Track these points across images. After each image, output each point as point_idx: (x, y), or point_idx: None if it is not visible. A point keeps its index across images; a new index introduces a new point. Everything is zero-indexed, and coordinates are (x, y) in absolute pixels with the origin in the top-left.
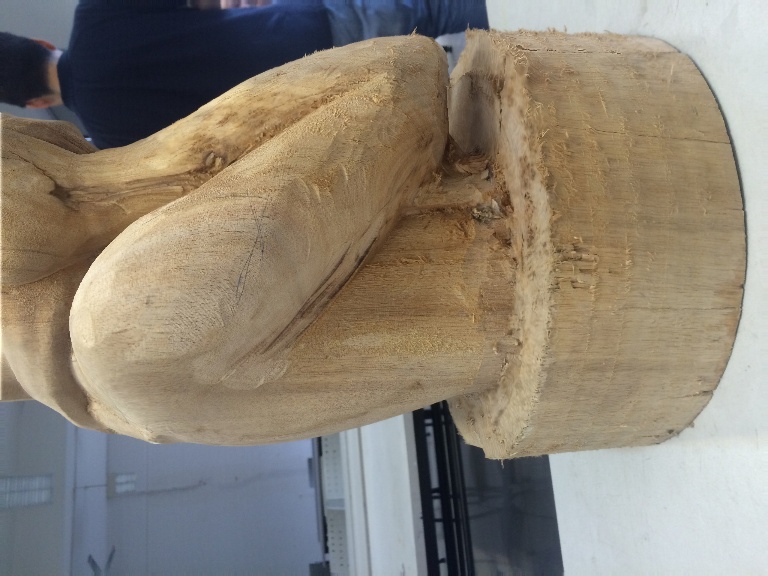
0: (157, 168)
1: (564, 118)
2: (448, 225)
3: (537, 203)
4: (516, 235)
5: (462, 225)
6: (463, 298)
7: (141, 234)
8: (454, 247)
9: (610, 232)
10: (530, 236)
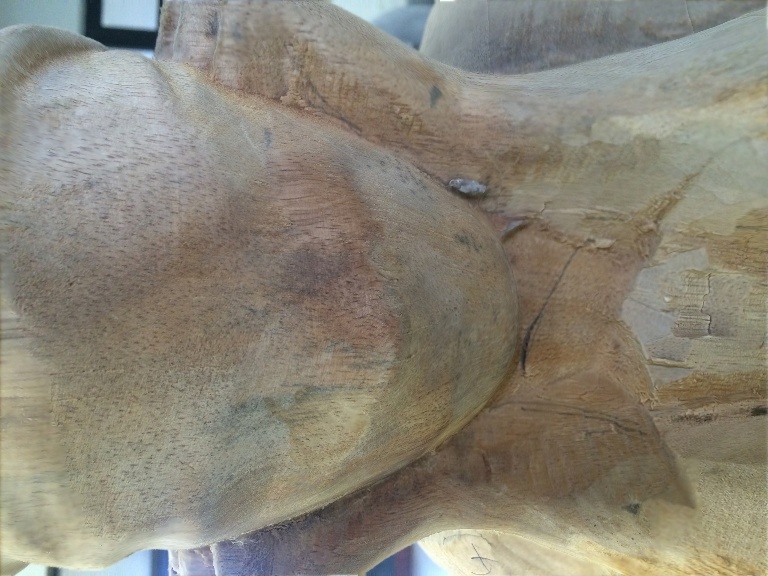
0: None
1: None
2: None
3: None
4: None
5: None
6: None
7: None
8: None
9: None
10: None
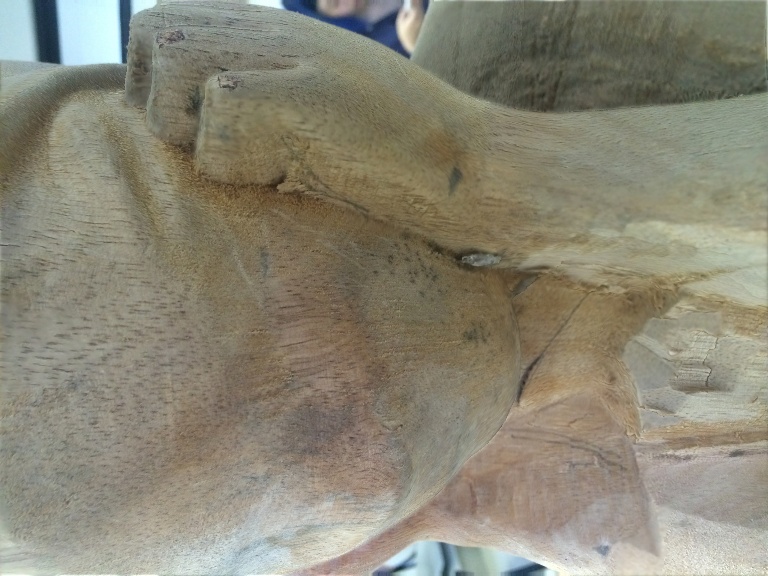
0: None
1: None
2: None
3: None
4: None
5: None
6: None
7: None
8: None
9: None
10: None
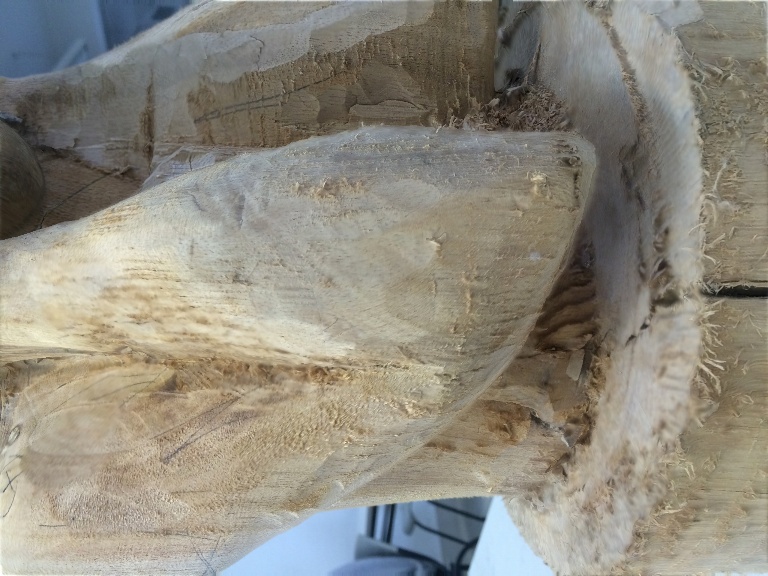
0: (40, 340)
1: (721, 478)
2: (492, 417)
3: (616, 515)
4: (578, 467)
5: (512, 424)
6: (484, 479)
7: (42, 550)
8: (491, 442)
9: (692, 567)
10: (591, 510)
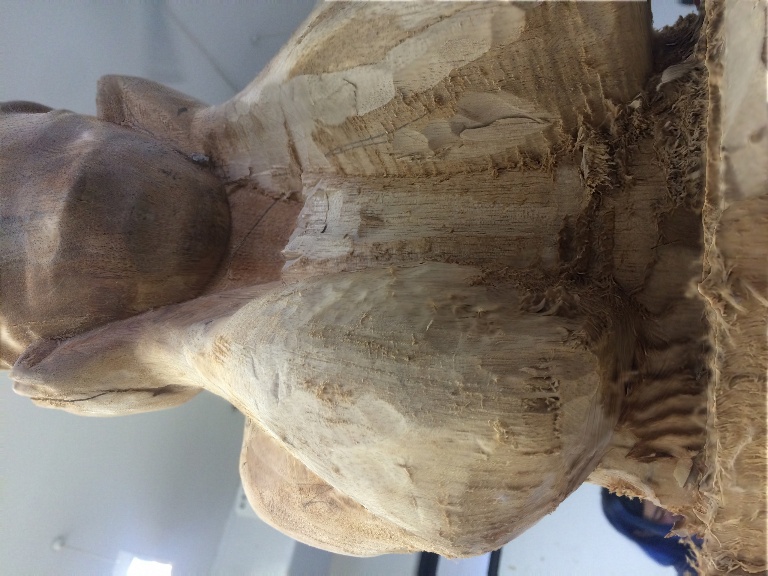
0: None
1: None
2: None
3: None
4: None
5: None
6: None
7: None
8: None
9: None
10: None
